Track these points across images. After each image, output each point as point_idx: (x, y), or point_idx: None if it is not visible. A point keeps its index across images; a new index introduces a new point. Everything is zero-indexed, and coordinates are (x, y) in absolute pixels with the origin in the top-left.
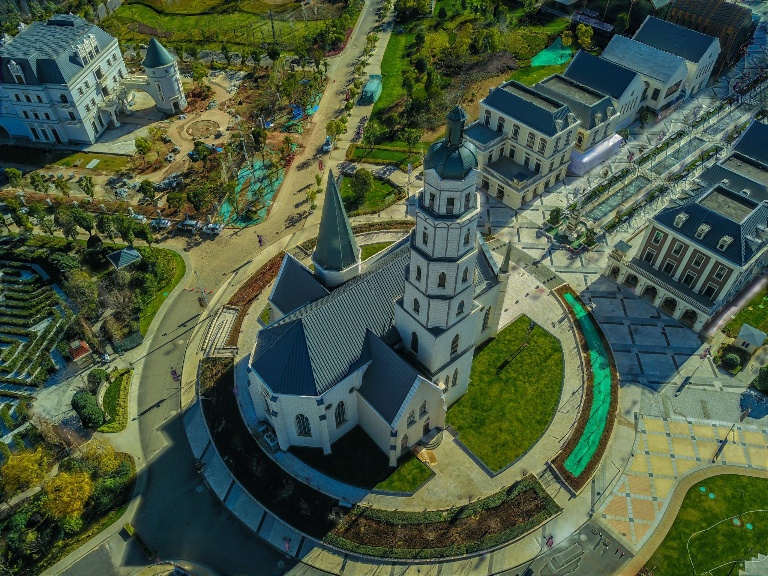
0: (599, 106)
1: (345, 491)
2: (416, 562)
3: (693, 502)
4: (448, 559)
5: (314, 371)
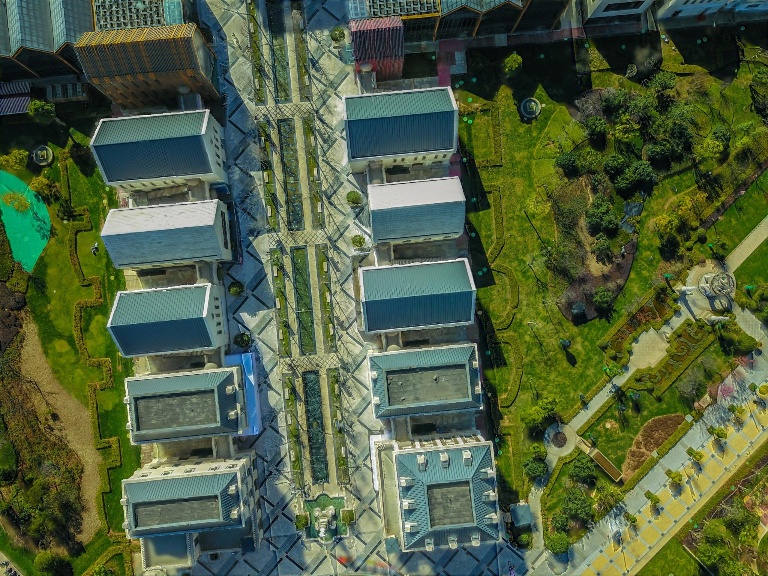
0: (221, 409)
1: None
2: None
3: None
4: None
5: None
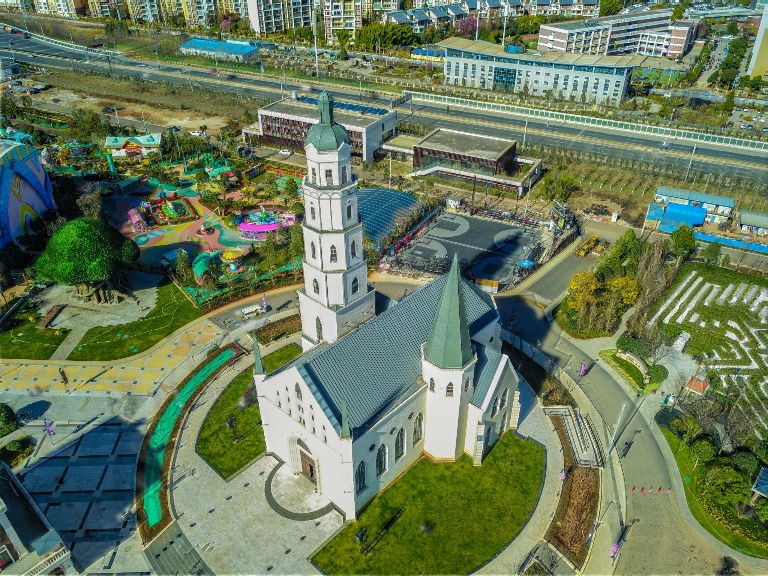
0: None
1: None
2: None
3: (149, 343)
4: None
5: None
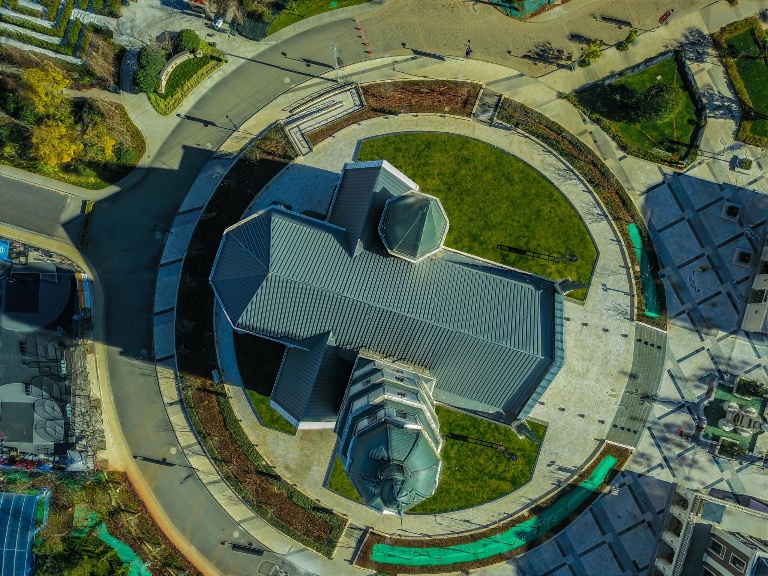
0: None
1: (230, 366)
2: (210, 460)
3: None
4: (228, 485)
5: (246, 311)
